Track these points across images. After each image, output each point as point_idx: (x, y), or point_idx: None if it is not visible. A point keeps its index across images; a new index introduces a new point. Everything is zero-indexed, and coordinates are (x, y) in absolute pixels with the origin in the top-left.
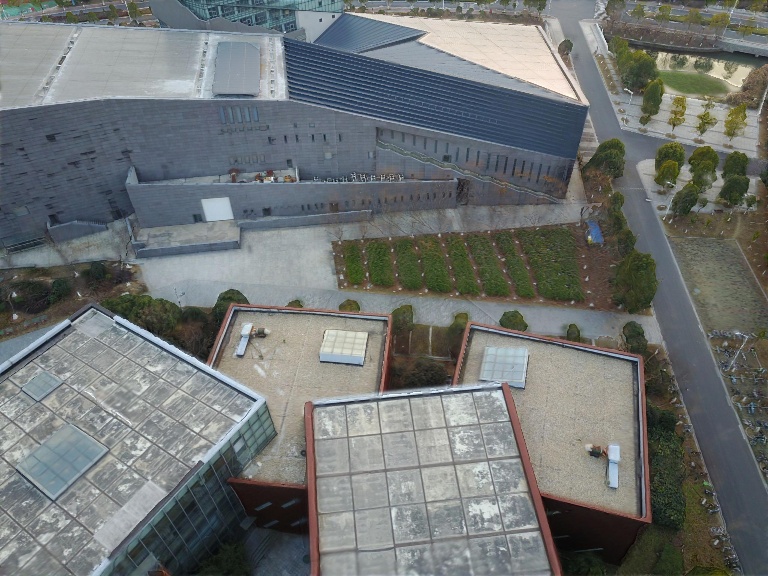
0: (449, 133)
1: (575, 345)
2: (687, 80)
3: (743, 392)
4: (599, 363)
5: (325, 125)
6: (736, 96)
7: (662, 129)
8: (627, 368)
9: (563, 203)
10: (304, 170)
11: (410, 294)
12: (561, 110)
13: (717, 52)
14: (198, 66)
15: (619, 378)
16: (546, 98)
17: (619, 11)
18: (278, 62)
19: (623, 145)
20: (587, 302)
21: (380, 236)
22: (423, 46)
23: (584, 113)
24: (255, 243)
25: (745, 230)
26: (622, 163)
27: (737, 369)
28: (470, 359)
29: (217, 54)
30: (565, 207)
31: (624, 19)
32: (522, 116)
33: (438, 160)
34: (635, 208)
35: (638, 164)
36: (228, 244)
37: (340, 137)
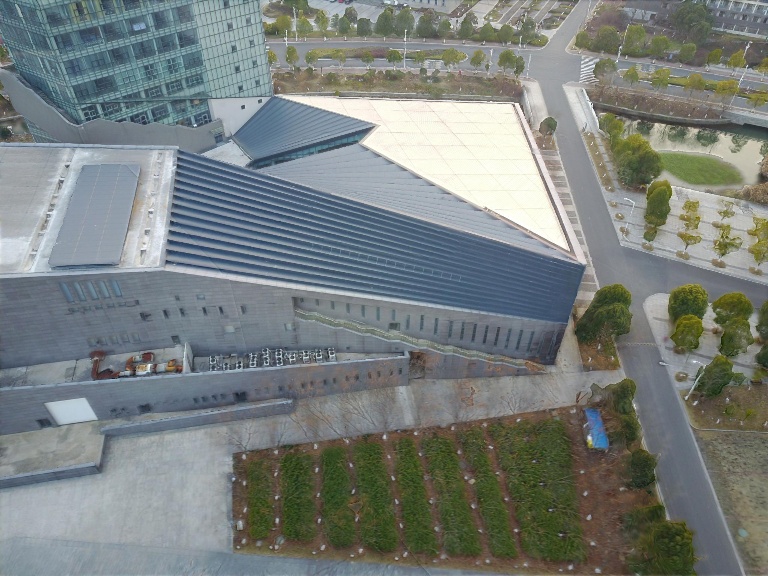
0: (395, 299)
1: None
2: (693, 165)
3: None
4: None
5: (219, 296)
6: (755, 191)
7: (671, 245)
8: None
9: (552, 372)
10: (198, 346)
11: (337, 557)
12: (548, 266)
13: (725, 124)
14: (44, 209)
15: None
16: (527, 250)
17: (609, 74)
18: (162, 196)
19: (629, 294)
20: (591, 564)
21: (302, 441)
22: (367, 152)
23: (579, 272)
24: (124, 461)
25: None
26: (628, 319)
27: None
28: None
29: (74, 188)
30: (554, 379)
31: (615, 82)
32: (495, 271)
33: (382, 331)
34: (647, 378)
35: (645, 302)
36: (81, 470)
37: (243, 309)
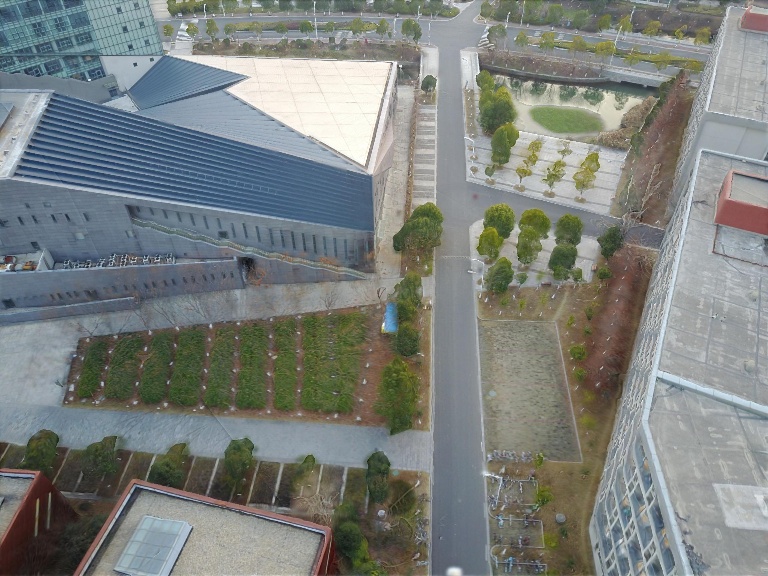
0: (216, 208)
1: (253, 513)
2: (562, 117)
3: (507, 540)
4: (279, 537)
5: (63, 204)
6: (607, 136)
7: (512, 180)
8: (312, 544)
9: (371, 278)
10: (56, 252)
11: (146, 409)
12: (345, 178)
13: (604, 82)
14: None
15: (296, 561)
16: (326, 165)
17: (501, 39)
18: (27, 127)
19: (437, 210)
20: (355, 414)
21: (140, 329)
22: (228, 96)
23: (369, 182)
24: None
25: (568, 310)
26: (436, 231)
27: (507, 507)
28: (117, 535)
29: None
30: (372, 283)
31: (510, 47)
32: (304, 185)
33: (210, 237)
34: (452, 283)
35: (472, 225)
36: None
37: (86, 216)
